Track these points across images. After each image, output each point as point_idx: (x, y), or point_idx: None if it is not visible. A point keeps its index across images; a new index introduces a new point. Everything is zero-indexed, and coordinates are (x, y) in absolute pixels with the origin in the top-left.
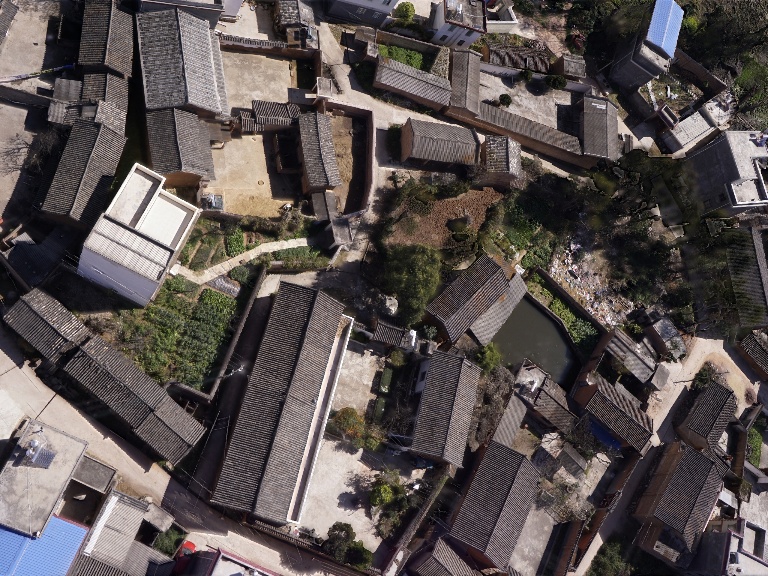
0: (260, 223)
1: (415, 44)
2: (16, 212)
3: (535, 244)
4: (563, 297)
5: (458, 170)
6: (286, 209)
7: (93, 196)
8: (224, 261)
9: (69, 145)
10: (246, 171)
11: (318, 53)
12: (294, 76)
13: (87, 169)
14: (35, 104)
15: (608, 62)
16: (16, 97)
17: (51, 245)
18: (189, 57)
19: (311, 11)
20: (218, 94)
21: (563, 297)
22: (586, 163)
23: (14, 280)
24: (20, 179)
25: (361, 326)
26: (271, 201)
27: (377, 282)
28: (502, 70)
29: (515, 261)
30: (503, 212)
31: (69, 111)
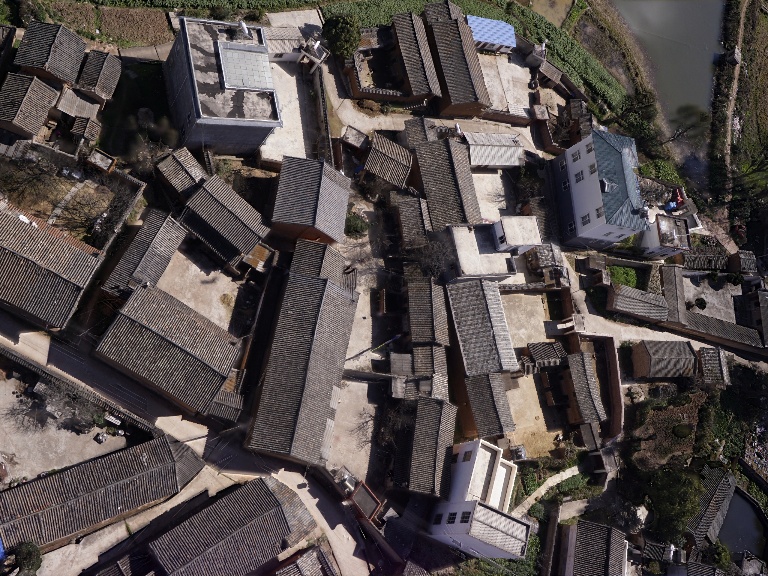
0: (550, 463)
1: (632, 263)
2: (373, 484)
3: (731, 433)
4: (757, 480)
5: (675, 378)
6: (559, 440)
7: (443, 469)
8: (524, 500)
9: (418, 423)
10: (525, 409)
11: (567, 288)
12: (546, 309)
13: (438, 446)
14: (378, 381)
15: (761, 245)
16: (362, 375)
17: (410, 515)
18: (494, 323)
19: (559, 250)
20: (513, 350)
21: (757, 480)
22: (763, 352)
23: (380, 549)
24: (372, 451)
25: (631, 545)
26: (547, 434)
27: (630, 496)
28: (693, 273)
29: (718, 452)
30: (714, 414)
31: (407, 386)
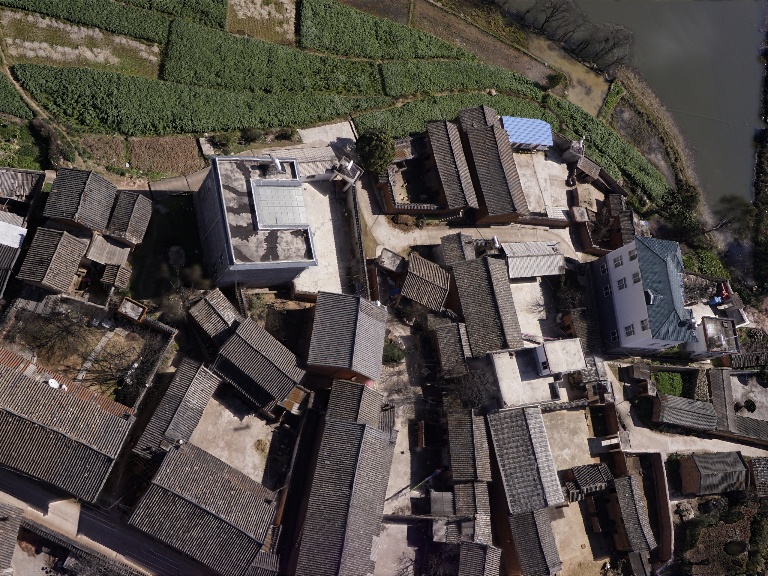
0: None
1: (677, 368)
2: None
3: None
4: None
5: None
6: (607, 570)
7: None
8: None
9: (461, 570)
10: (571, 537)
11: (611, 403)
12: (590, 425)
13: None
14: (418, 523)
15: None
16: None
17: None
18: (538, 455)
19: (602, 362)
20: (558, 480)
21: None
22: None
23: None
24: None
25: None
26: (594, 564)
27: None
28: (740, 372)
29: None
30: (767, 527)
31: (449, 528)
